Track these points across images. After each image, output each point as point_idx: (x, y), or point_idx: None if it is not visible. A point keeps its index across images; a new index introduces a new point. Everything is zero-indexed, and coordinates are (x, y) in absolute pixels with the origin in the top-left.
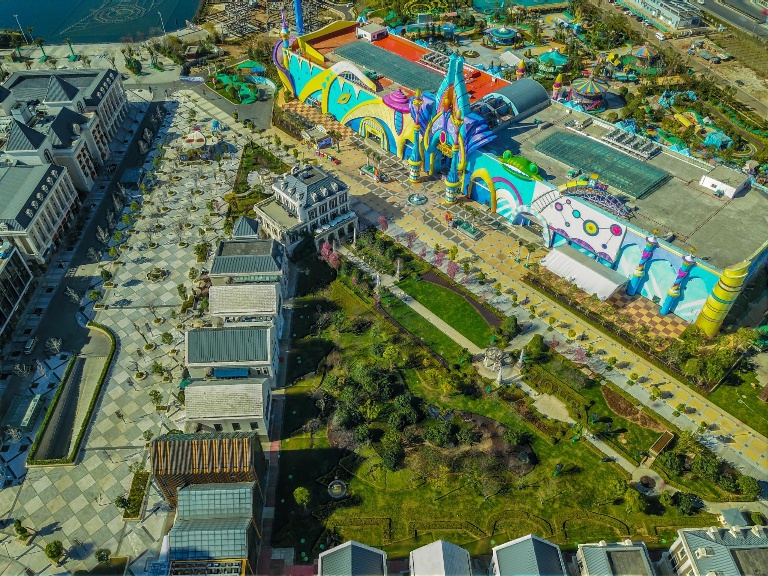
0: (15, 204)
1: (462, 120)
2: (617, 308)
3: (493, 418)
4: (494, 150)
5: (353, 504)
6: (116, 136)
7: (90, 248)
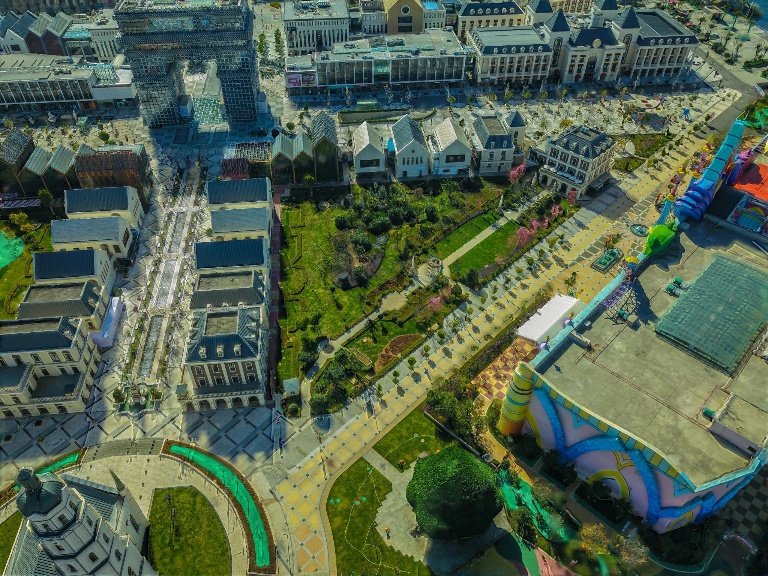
0: (500, 43)
1: (685, 172)
2: (524, 360)
3: (380, 269)
4: (690, 226)
5: (314, 212)
6: (640, 78)
7: (490, 87)
